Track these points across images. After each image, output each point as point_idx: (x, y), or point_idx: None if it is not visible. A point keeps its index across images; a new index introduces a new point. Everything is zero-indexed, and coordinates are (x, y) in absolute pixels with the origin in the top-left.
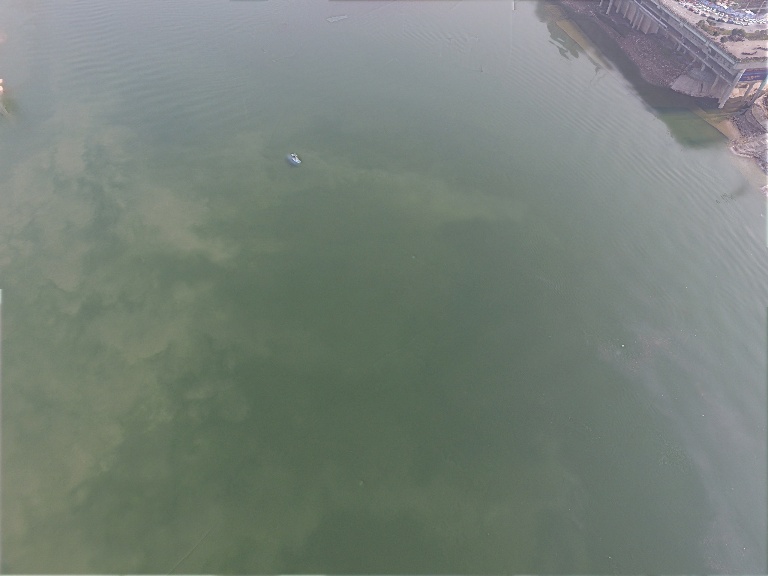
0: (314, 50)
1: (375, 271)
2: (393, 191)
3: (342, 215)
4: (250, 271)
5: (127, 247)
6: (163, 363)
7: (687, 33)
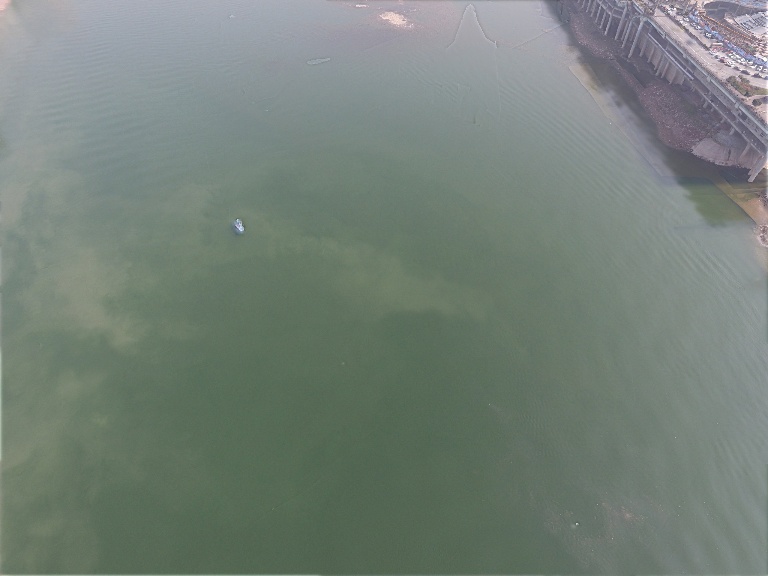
0: (295, 93)
1: (293, 380)
2: (339, 272)
3: (274, 300)
4: (152, 369)
5: (28, 328)
6: (20, 488)
7: (715, 89)
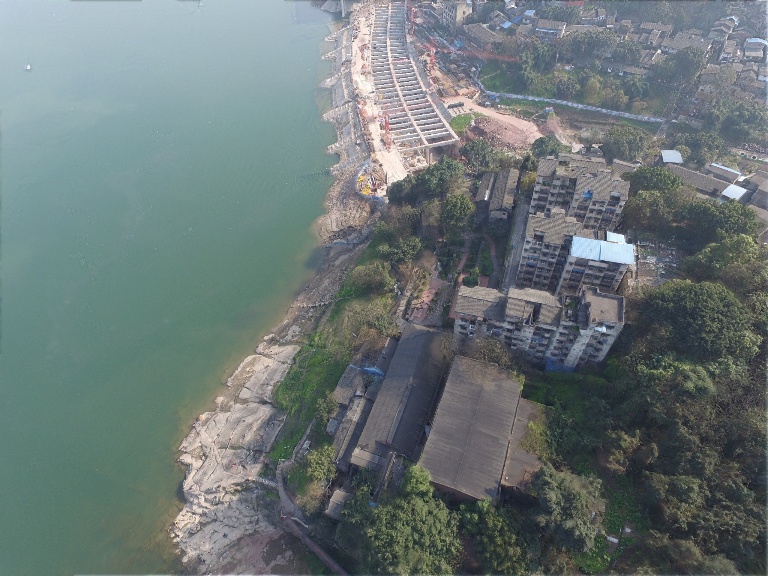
0: (85, 8)
1: (42, 116)
2: (83, 79)
3: (42, 93)
4: None
5: None
6: None
7: None
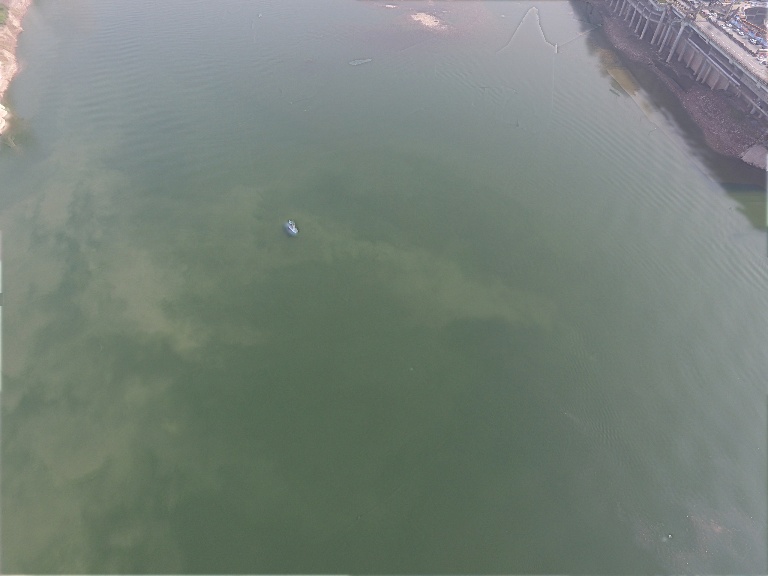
0: (334, 93)
1: (363, 385)
2: (398, 276)
3: (335, 304)
4: (217, 372)
5: (87, 329)
6: (94, 494)
7: (765, 95)
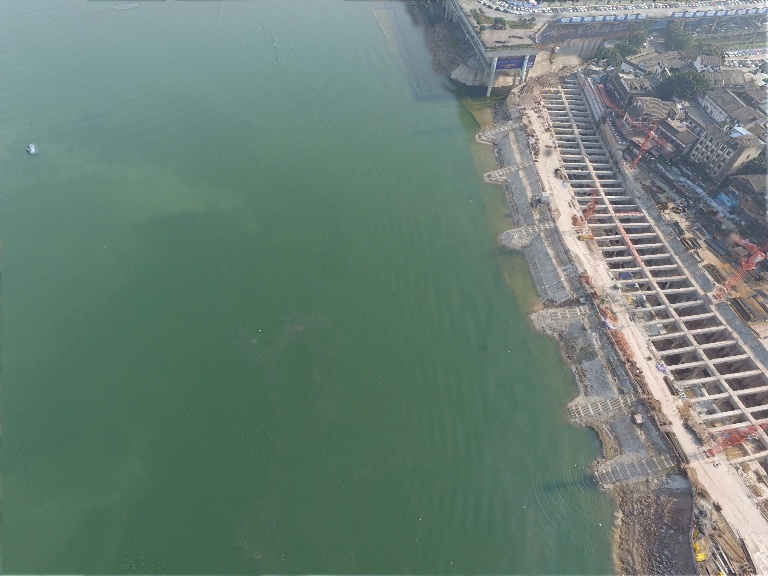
0: (111, 39)
1: (57, 261)
2: (118, 181)
3: (54, 205)
4: None
5: None
6: None
7: None
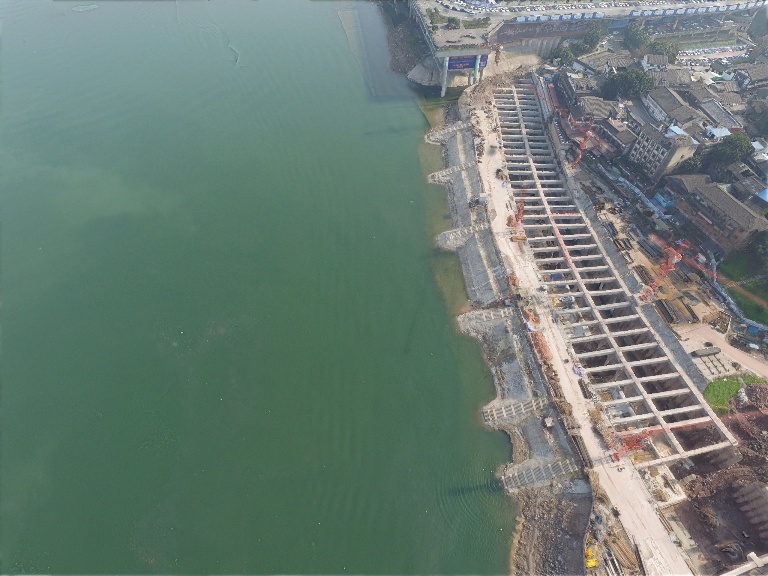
0: (72, 40)
1: None
2: (61, 182)
3: None
4: None
5: None
6: None
7: None
